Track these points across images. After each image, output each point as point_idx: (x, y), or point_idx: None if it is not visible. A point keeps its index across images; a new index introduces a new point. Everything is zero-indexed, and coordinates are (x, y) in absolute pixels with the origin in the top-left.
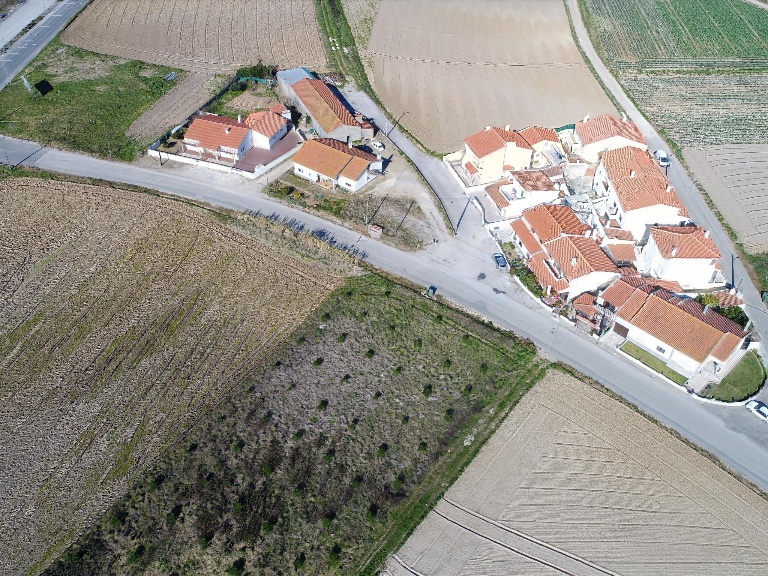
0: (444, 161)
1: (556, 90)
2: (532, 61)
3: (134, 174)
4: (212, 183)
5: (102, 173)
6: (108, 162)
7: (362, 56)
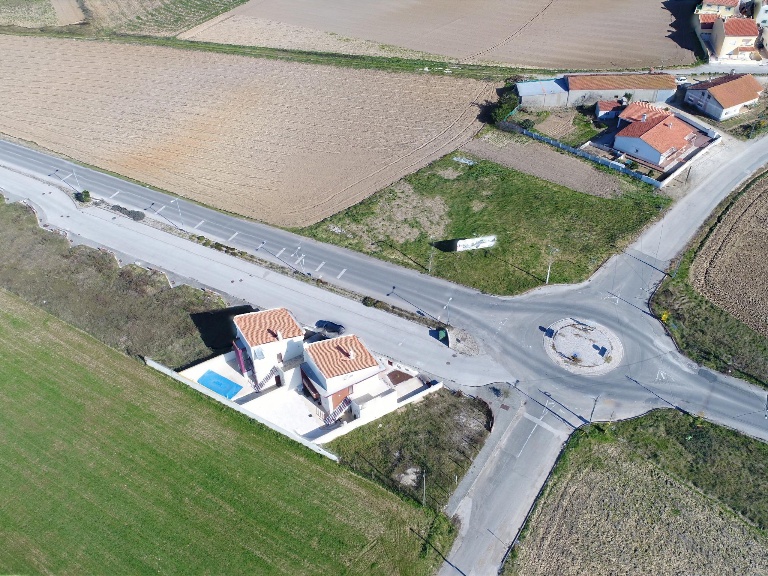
0: (711, 63)
1: (603, 6)
2: (541, 3)
3: (699, 201)
4: (724, 162)
5: (693, 219)
6: (670, 213)
7: (475, 63)
